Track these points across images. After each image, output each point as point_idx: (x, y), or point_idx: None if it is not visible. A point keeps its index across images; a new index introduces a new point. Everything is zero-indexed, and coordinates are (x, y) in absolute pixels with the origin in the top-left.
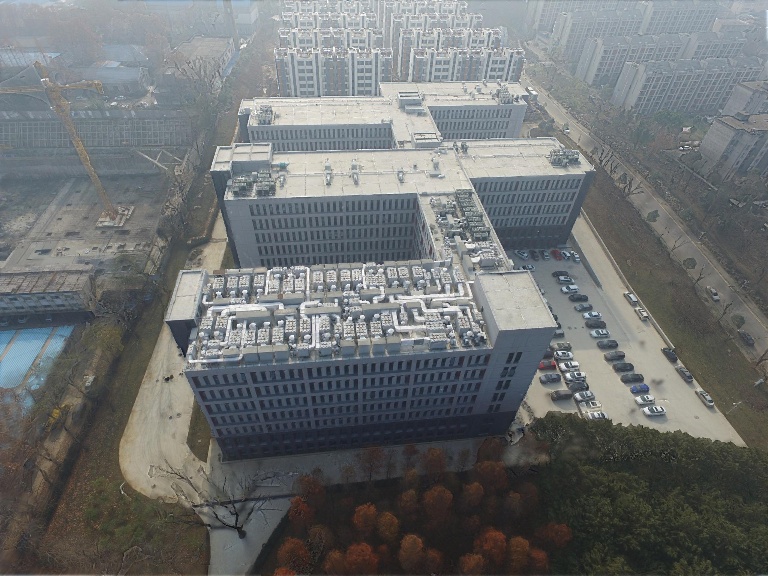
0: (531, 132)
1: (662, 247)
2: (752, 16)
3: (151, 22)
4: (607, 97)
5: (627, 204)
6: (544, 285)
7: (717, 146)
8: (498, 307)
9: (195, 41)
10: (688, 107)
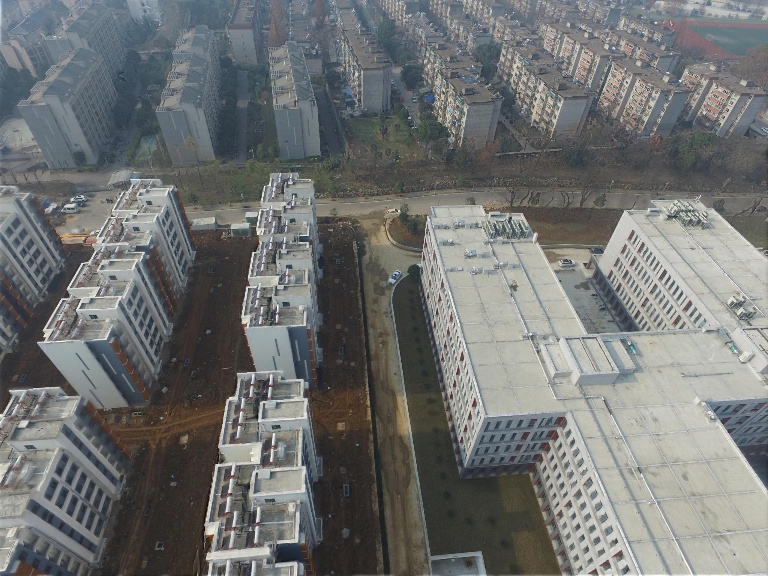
0: (410, 245)
1: None
2: (148, 7)
3: None
4: None
5: (582, 211)
6: None
7: (482, 124)
8: None
9: None
10: None
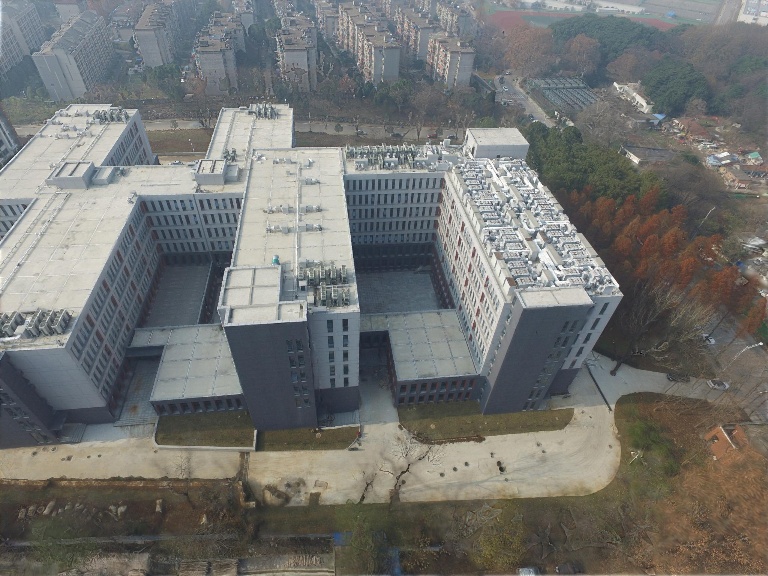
0: None
1: (319, 133)
2: None
3: None
4: (45, 98)
5: None
6: None
7: (217, 71)
8: (508, 143)
9: None
10: (102, 72)
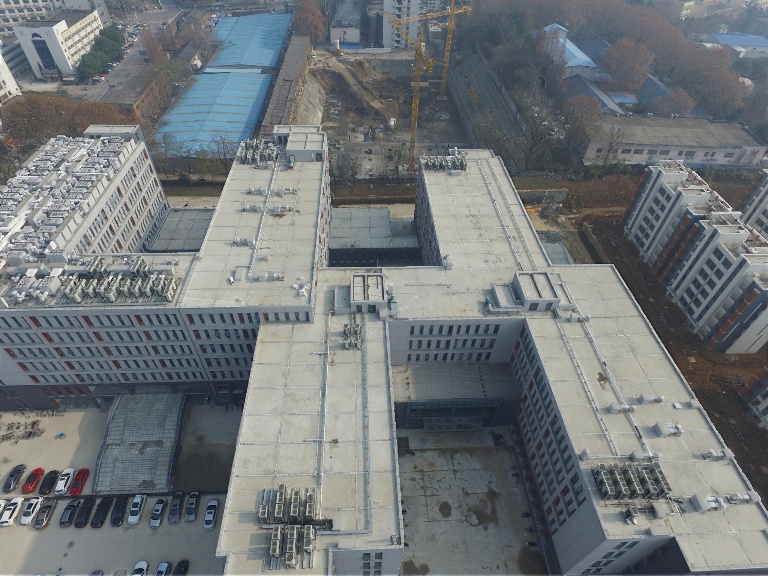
0: None
1: None
2: None
3: (723, 86)
4: None
5: None
6: (170, 535)
7: None
8: None
9: (721, 125)
10: None
